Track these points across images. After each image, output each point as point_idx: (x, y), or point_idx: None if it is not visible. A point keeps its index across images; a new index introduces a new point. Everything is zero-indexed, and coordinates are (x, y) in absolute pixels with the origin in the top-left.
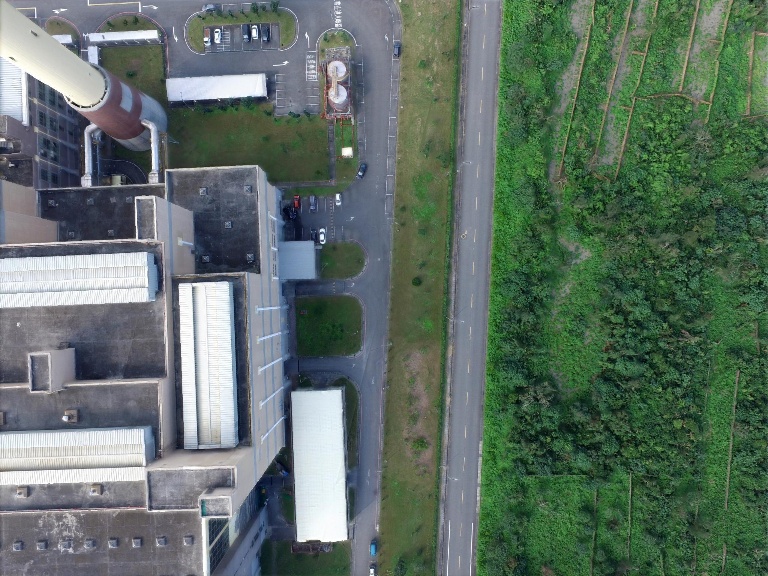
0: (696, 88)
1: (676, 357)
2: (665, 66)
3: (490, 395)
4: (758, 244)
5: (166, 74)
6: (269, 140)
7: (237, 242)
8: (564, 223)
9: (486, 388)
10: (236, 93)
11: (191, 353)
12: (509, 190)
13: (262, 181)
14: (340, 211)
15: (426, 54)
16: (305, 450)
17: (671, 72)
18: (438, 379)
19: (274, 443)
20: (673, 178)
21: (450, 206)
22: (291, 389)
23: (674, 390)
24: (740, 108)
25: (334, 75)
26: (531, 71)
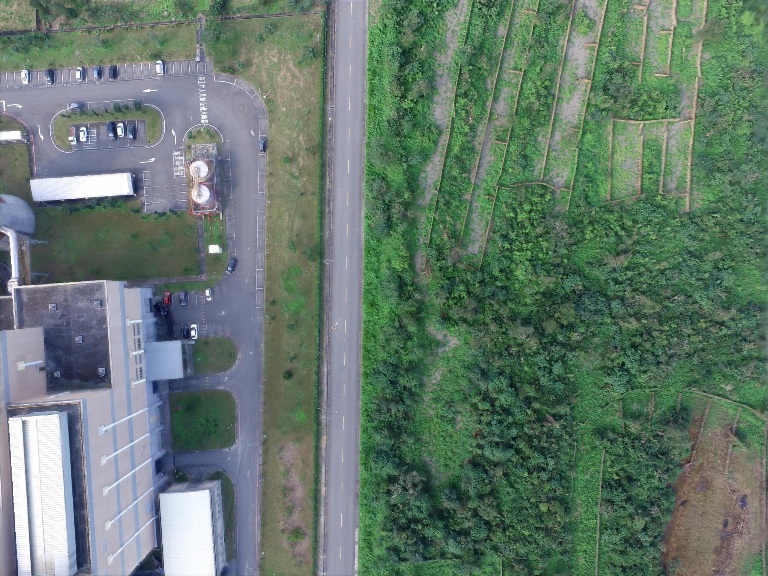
0: (557, 175)
1: (541, 441)
2: (527, 155)
3: (363, 484)
4: (620, 326)
5: (33, 173)
6: (138, 237)
7: (88, 356)
8: (432, 312)
9: (360, 477)
10: (102, 192)
11: (22, 487)
12: (377, 281)
13: (115, 293)
14: (211, 306)
15: (292, 149)
16: (174, 552)
17: (533, 160)
18: (312, 470)
19: (136, 552)
20: (535, 266)
21: (318, 300)
22: (167, 485)
23: (539, 474)
24: (602, 192)
25: (195, 176)
26: (393, 165)
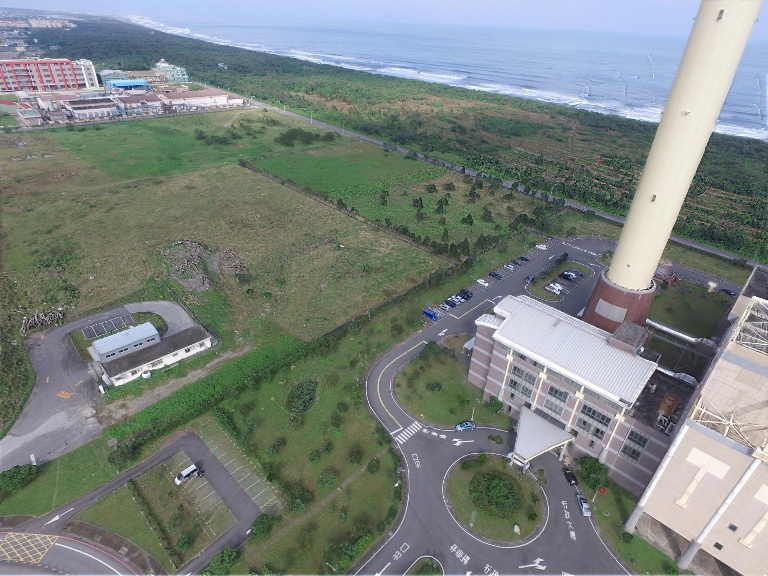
0: None
1: None
2: None
3: None
4: None
5: None
6: None
7: None
8: None
9: None
10: None
11: None
12: None
13: None
14: None
15: None
16: None
17: None
18: None
19: None
20: None
21: None
22: None
23: None
24: None
25: None
26: None
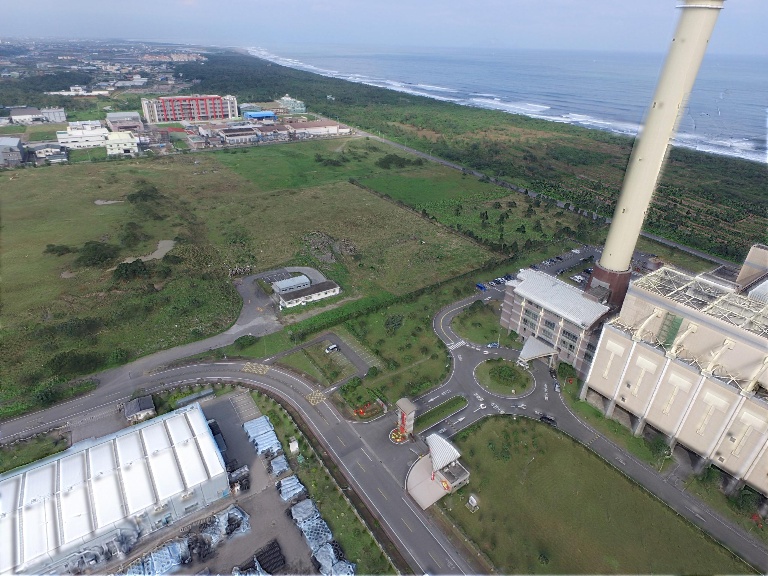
0: None
1: None
2: None
3: None
4: None
5: None
6: None
7: None
8: None
9: None
10: None
11: None
12: None
13: None
14: None
15: None
16: None
17: None
18: None
19: None
20: None
21: None
22: None
23: None
24: None
25: None
26: None
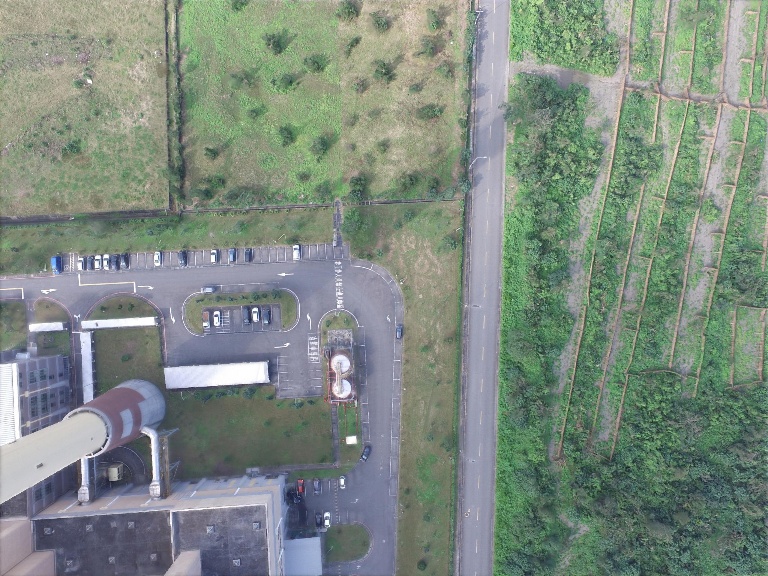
0: (684, 362)
1: None
2: (655, 342)
3: None
4: (742, 512)
5: (163, 356)
6: (271, 424)
7: None
8: (563, 500)
9: None
10: (237, 381)
11: None
12: (510, 469)
13: (270, 510)
14: (344, 493)
15: (428, 336)
16: None
17: (661, 347)
18: None
19: None
20: (665, 455)
21: (454, 490)
22: None
23: None
24: (724, 376)
25: (338, 372)
26: (530, 356)
